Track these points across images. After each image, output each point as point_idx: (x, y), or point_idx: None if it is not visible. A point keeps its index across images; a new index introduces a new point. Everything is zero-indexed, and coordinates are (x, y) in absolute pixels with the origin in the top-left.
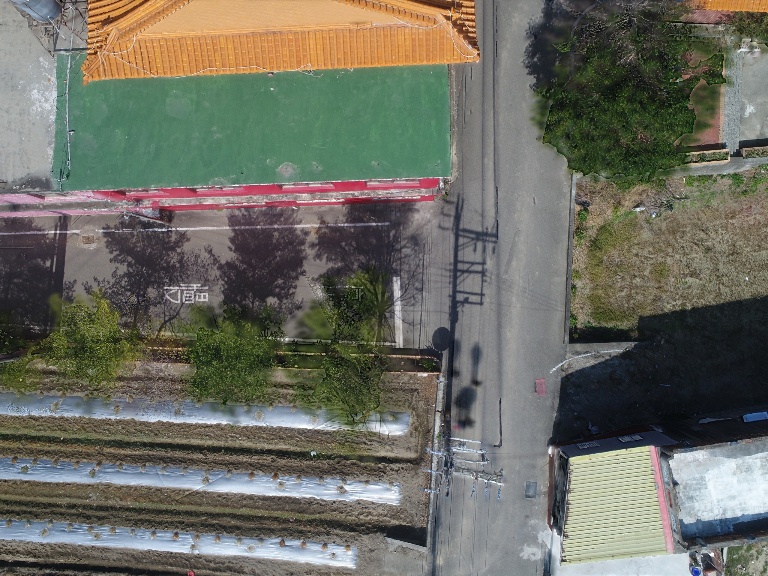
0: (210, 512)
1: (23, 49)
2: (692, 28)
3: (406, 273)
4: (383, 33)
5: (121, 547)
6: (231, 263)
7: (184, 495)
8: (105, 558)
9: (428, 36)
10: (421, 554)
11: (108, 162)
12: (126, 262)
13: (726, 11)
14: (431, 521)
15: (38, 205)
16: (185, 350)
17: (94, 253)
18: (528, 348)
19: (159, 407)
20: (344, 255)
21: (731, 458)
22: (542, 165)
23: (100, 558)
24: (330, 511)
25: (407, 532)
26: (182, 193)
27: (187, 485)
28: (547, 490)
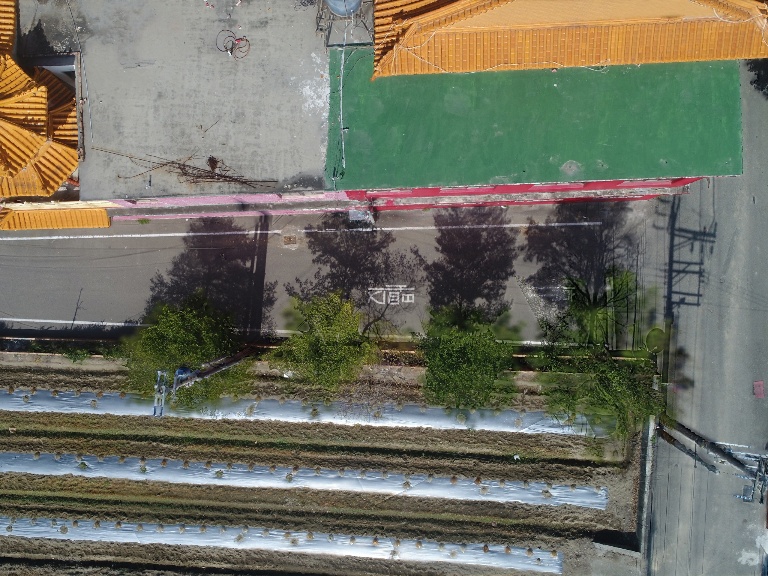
0: (409, 517)
1: (294, 44)
2: None
3: (619, 273)
4: (689, 27)
5: (319, 553)
6: (438, 263)
7: (384, 500)
8: (302, 564)
9: (736, 30)
10: (634, 559)
11: (384, 160)
12: (329, 263)
13: None
14: (645, 526)
15: (268, 205)
16: (392, 352)
17: (296, 253)
18: (747, 350)
19: (358, 410)
20: (555, 255)
21: None
22: (762, 163)
23: (297, 564)
24: (535, 516)
25: (614, 537)
26: (427, 192)
27: (387, 490)
28: (766, 494)
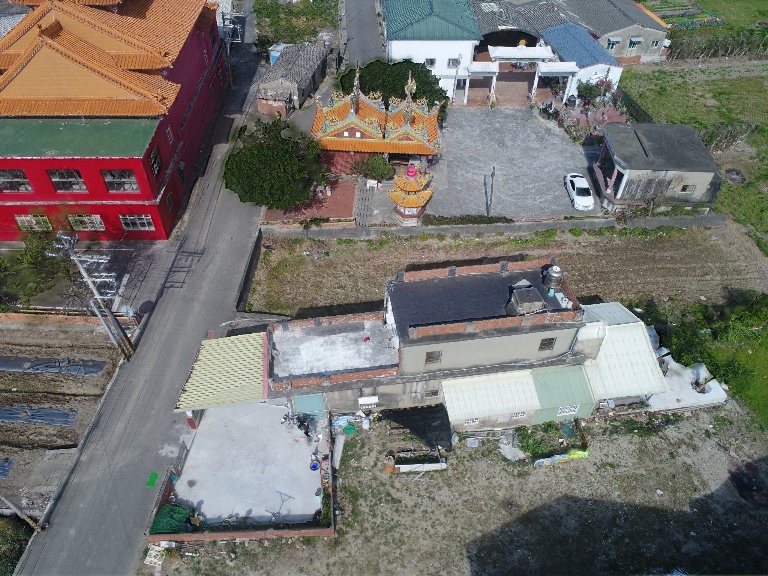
0: None
1: None
2: (339, 175)
3: (135, 273)
4: (123, 103)
5: None
6: None
7: None
8: None
9: (145, 105)
10: (70, 455)
11: None
12: None
13: (351, 163)
14: None
15: None
16: None
17: None
18: (207, 311)
19: None
20: None
21: (321, 336)
22: (241, 224)
23: None
24: (5, 431)
25: None
26: None
27: None
28: None
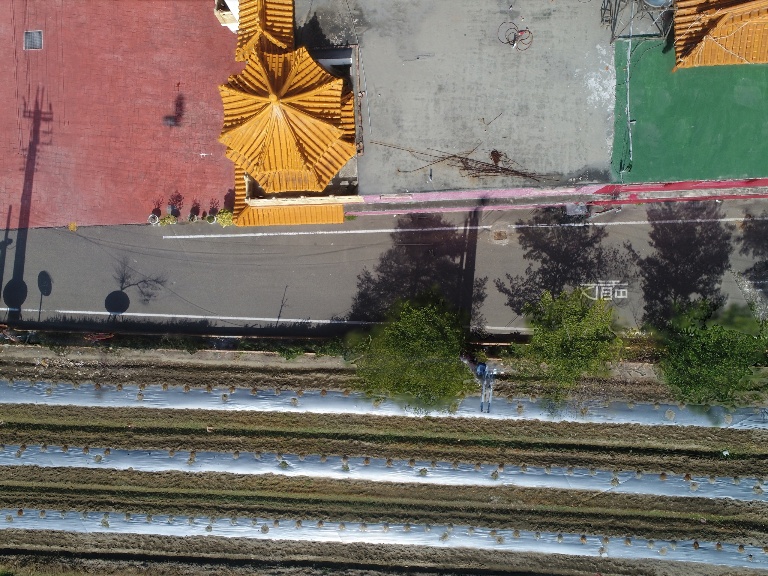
0: (616, 514)
1: (578, 36)
2: None
3: None
4: None
5: (525, 551)
6: (652, 258)
7: (591, 497)
8: (508, 562)
9: None
10: None
11: (672, 153)
12: (541, 258)
13: None
14: None
15: (508, 199)
16: None
17: (506, 249)
18: None
19: (564, 407)
20: None
21: None
22: None
23: (503, 562)
24: (745, 512)
25: None
26: None
27: (595, 487)
28: None
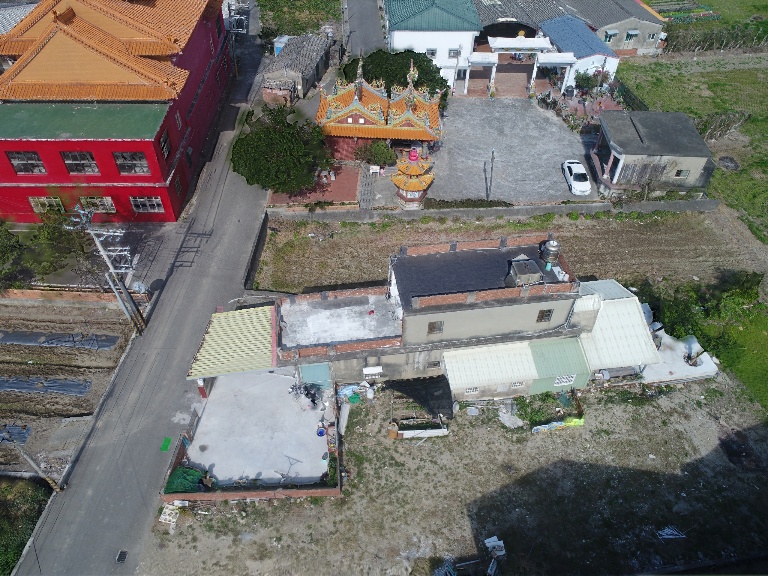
0: None
1: None
2: (343, 161)
3: (145, 253)
4: (134, 88)
5: None
6: (28, 246)
7: None
8: None
9: (155, 89)
10: (86, 422)
11: None
12: None
13: (355, 150)
14: (104, 396)
15: None
16: None
17: None
18: (216, 289)
19: None
20: (107, 244)
21: (327, 310)
22: (248, 207)
23: None
24: (23, 401)
25: None
26: (7, 172)
27: None
28: None
